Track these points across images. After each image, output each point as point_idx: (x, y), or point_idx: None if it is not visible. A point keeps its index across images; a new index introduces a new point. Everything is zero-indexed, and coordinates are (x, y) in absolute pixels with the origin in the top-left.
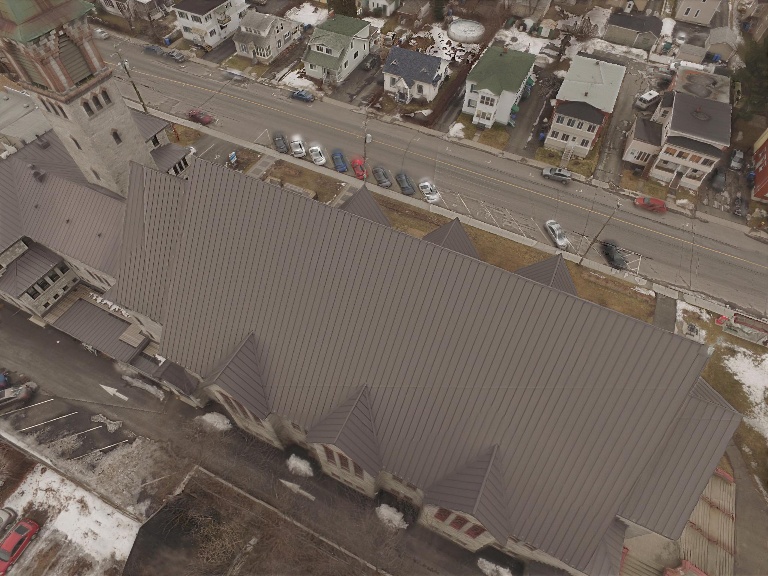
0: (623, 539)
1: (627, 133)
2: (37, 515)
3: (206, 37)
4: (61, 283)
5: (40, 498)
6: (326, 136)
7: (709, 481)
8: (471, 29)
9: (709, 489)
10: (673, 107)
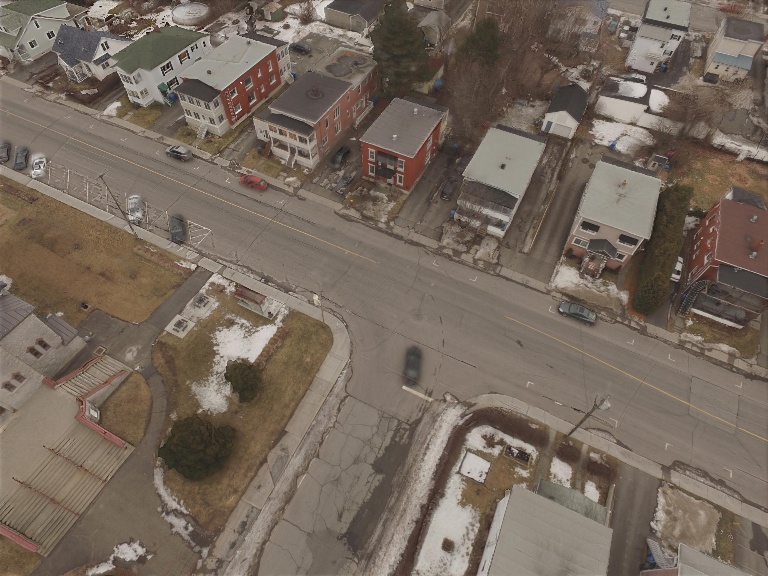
0: None
1: None
2: None
3: None
4: None
5: None
6: None
7: (95, 444)
8: (194, 11)
9: (89, 451)
10: None
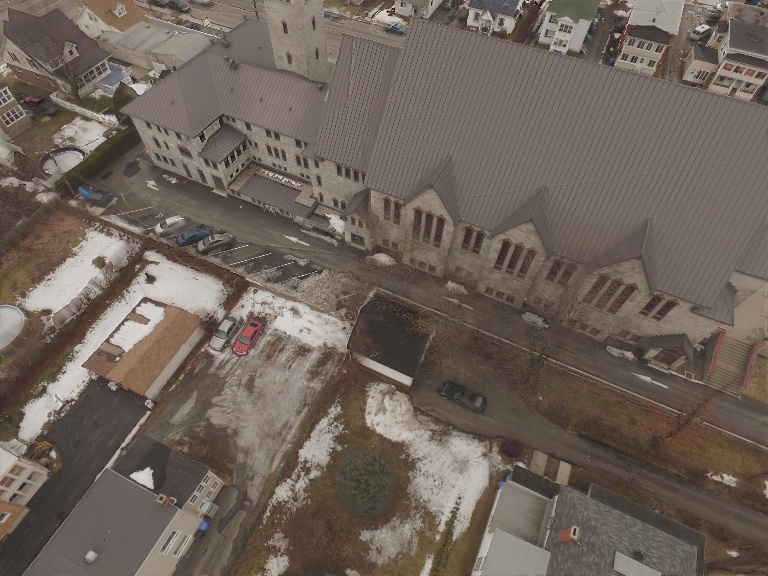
0: (734, 299)
1: (684, 59)
2: (258, 320)
3: None
4: (241, 159)
5: (258, 309)
6: None
7: None
8: None
9: None
10: (729, 31)
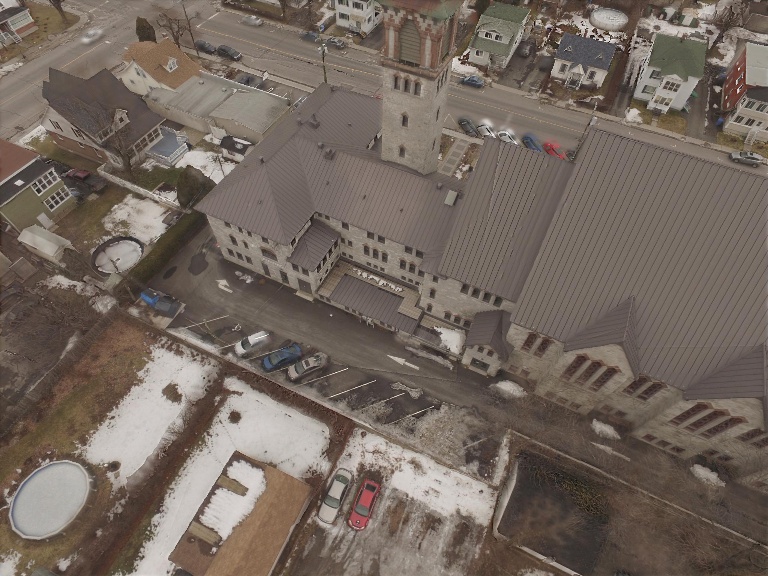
0: None
1: None
2: (371, 475)
3: (363, 24)
4: (331, 259)
5: (369, 460)
6: (509, 121)
7: None
8: (614, 17)
9: None
10: None
